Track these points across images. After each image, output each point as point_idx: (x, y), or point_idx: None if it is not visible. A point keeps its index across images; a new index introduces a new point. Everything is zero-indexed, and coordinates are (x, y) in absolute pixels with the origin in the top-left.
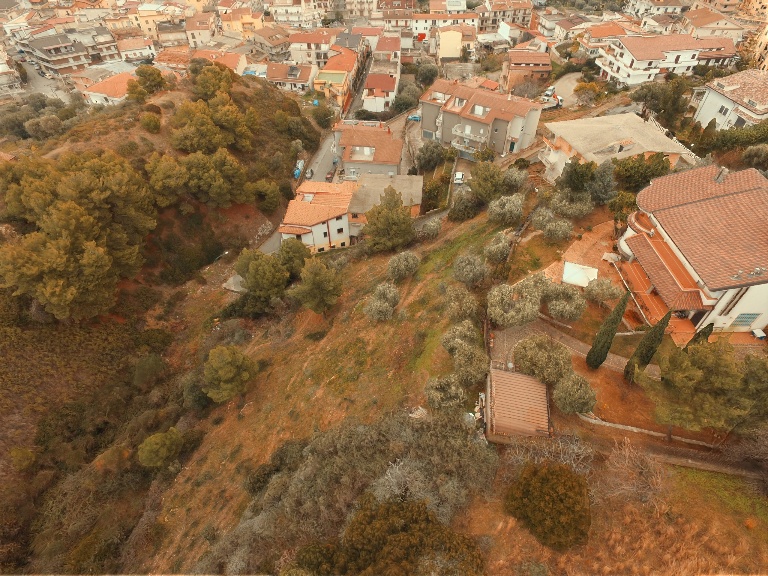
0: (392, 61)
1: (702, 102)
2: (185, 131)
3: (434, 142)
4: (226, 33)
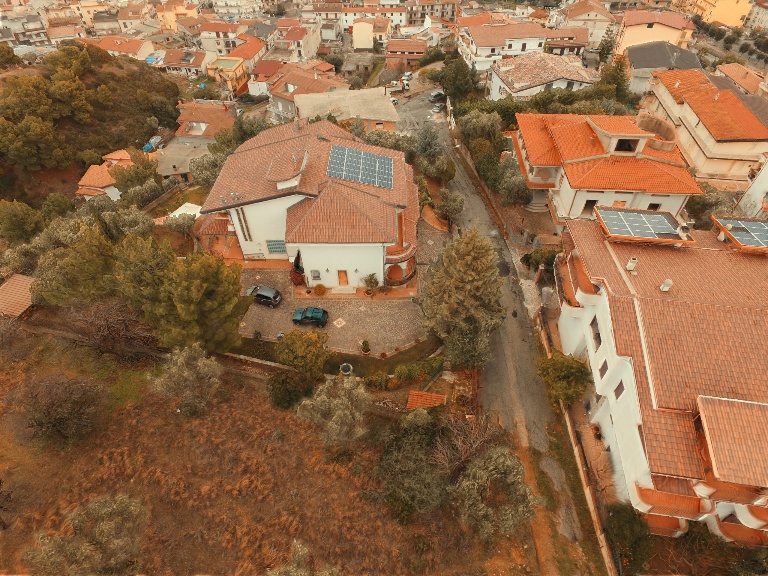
0: (290, 49)
1: (491, 83)
2: (7, 101)
3: None
4: (147, 22)
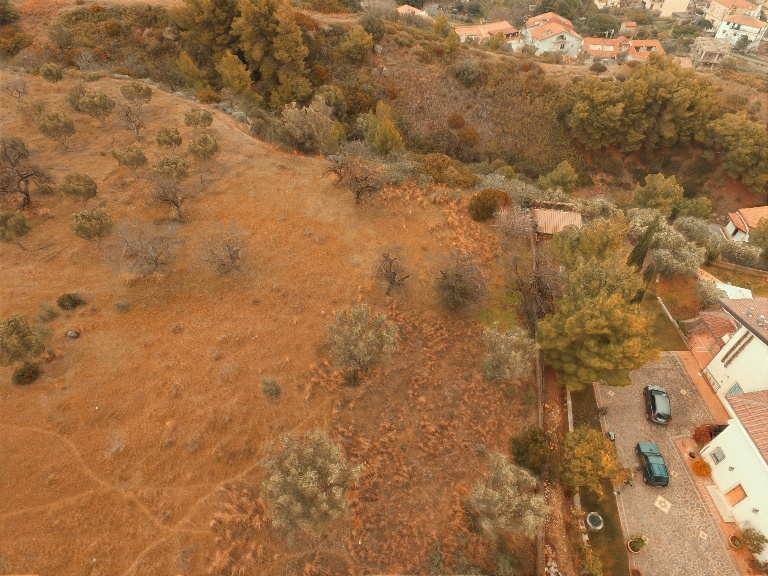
0: None
1: None
2: None
3: None
4: None
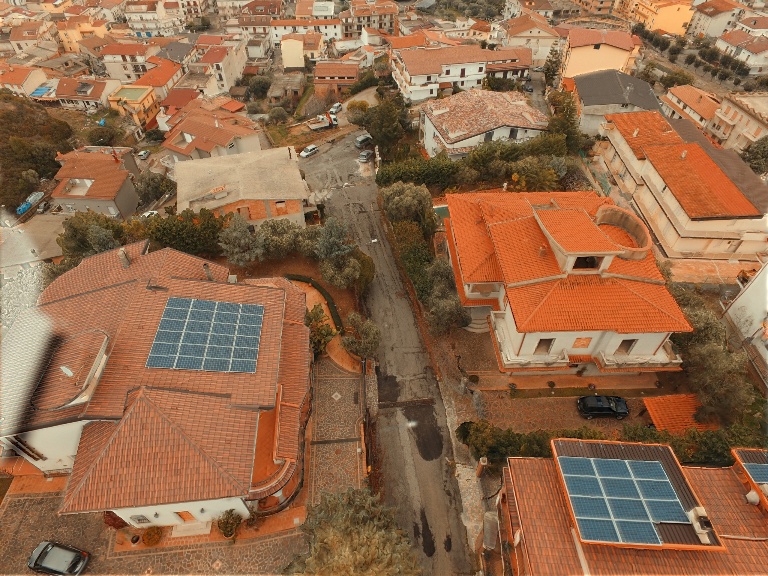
0: (207, 74)
1: (424, 126)
2: None
3: (151, 173)
4: (41, 44)
